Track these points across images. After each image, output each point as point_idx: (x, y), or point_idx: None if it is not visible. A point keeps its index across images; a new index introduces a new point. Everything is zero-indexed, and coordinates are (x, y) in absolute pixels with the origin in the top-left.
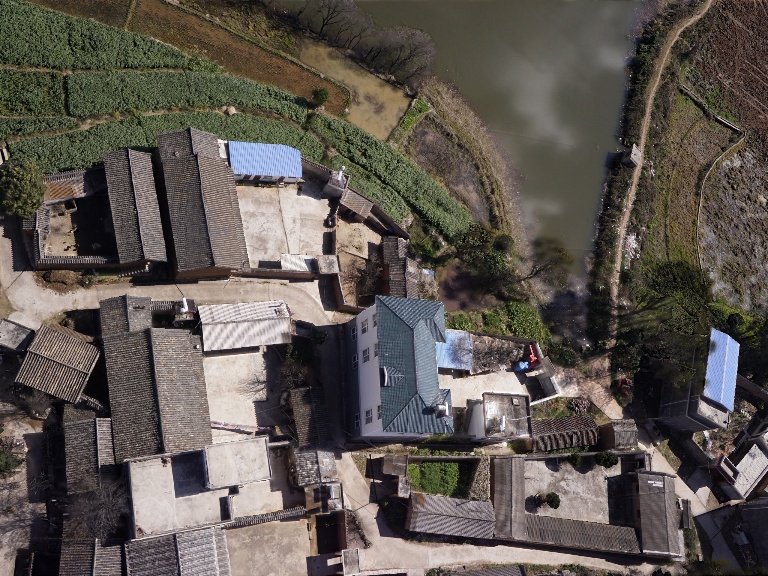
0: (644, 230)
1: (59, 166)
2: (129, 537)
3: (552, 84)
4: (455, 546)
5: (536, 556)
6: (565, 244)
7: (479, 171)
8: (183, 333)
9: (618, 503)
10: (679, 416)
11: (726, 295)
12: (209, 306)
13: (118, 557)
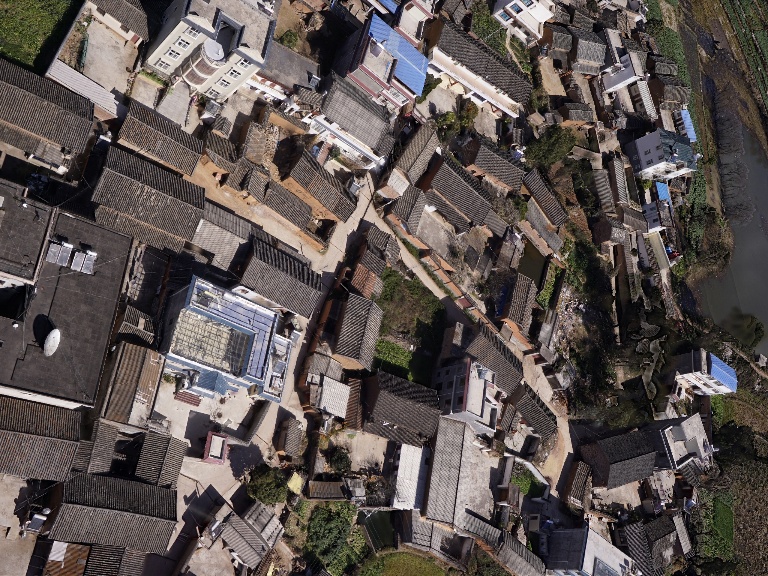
0: None
1: None
2: None
3: (759, 314)
4: None
5: None
6: None
7: (715, 253)
8: (645, 69)
9: None
10: (686, 353)
11: None
12: None
13: (590, 30)
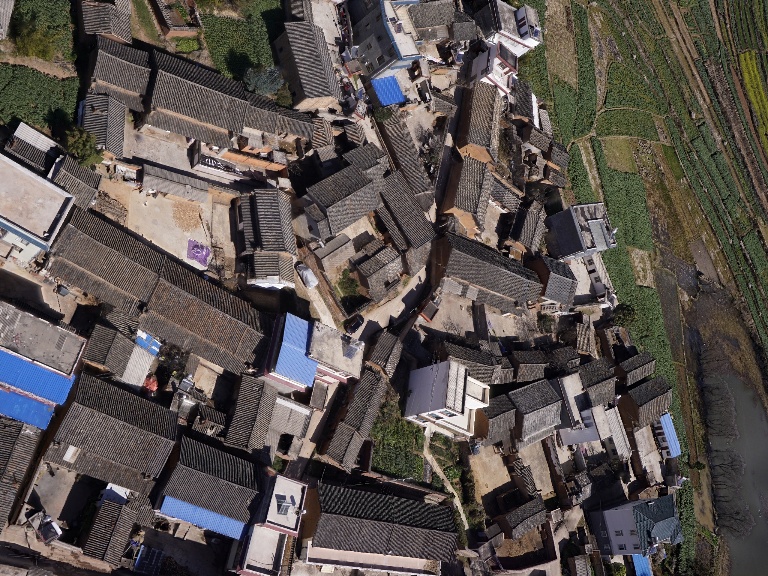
0: None
1: None
2: None
3: None
4: None
5: None
6: None
7: None
8: (614, 396)
9: None
10: None
11: None
12: None
13: (540, 377)
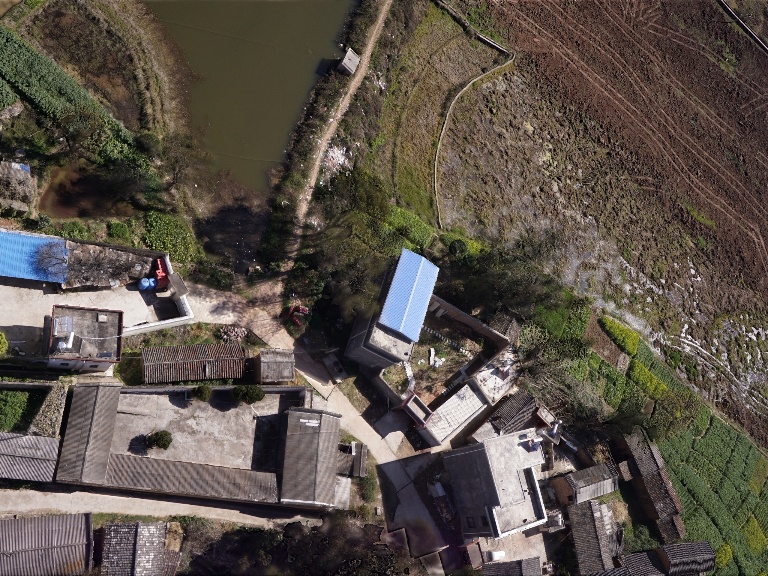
0: (359, 146)
1: None
2: None
3: None
4: (7, 491)
5: (133, 505)
6: (246, 154)
7: (133, 63)
8: None
9: (268, 446)
10: (358, 348)
11: (466, 225)
12: None
13: None
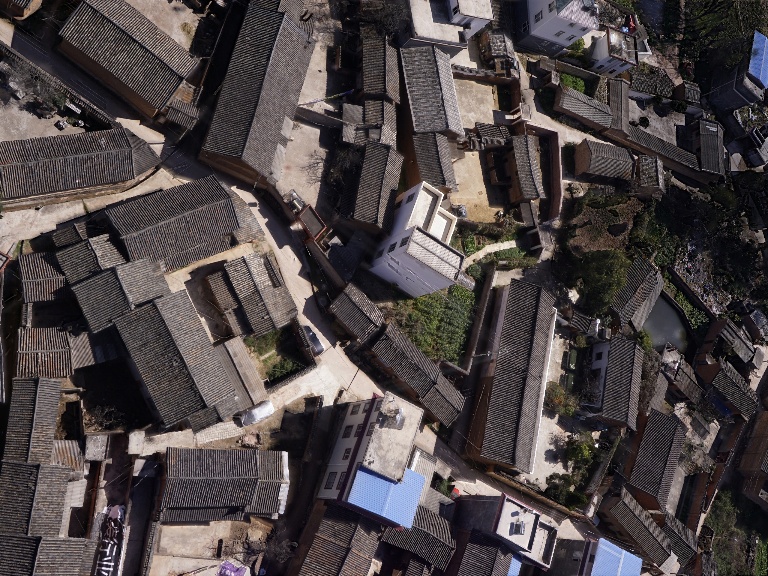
0: None
1: None
2: (403, 44)
3: None
4: (582, 133)
5: None
6: None
7: None
8: None
9: (683, 143)
10: (727, 92)
11: None
12: None
13: (396, 56)
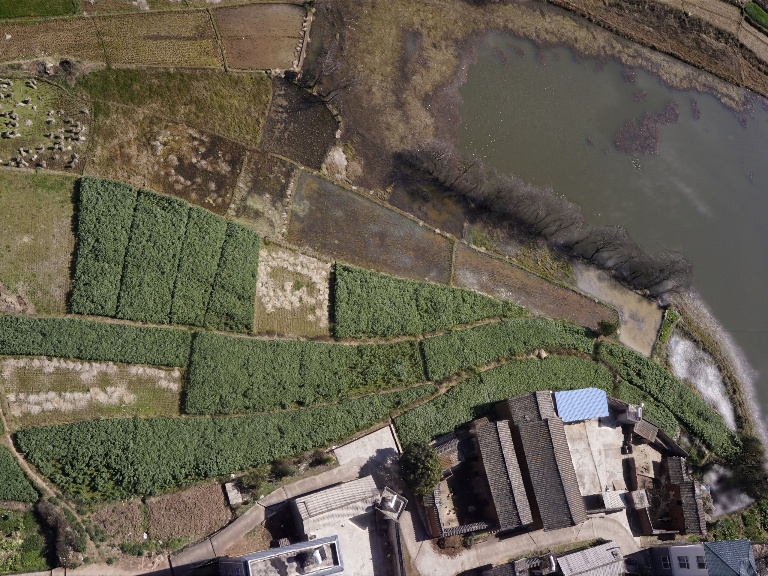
0: None
1: (432, 434)
2: None
3: (764, 273)
4: None
5: None
6: None
7: (721, 373)
8: None
9: None
10: None
11: None
12: (565, 557)
13: None
